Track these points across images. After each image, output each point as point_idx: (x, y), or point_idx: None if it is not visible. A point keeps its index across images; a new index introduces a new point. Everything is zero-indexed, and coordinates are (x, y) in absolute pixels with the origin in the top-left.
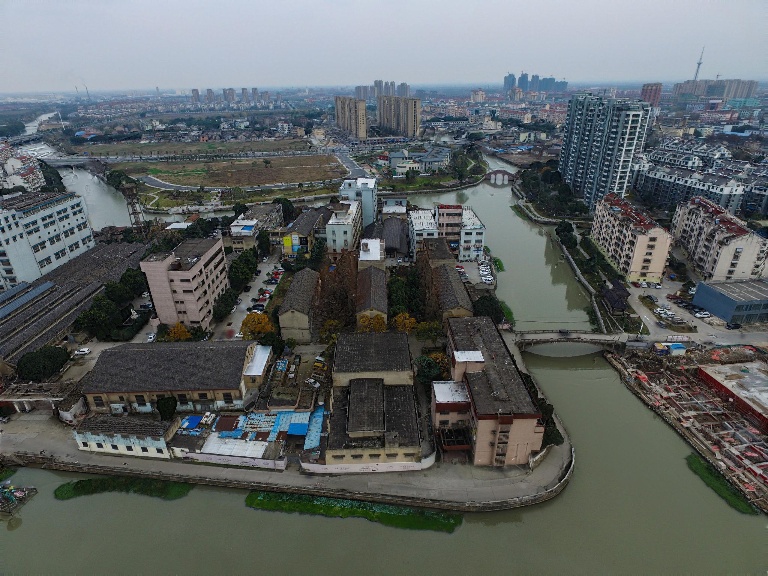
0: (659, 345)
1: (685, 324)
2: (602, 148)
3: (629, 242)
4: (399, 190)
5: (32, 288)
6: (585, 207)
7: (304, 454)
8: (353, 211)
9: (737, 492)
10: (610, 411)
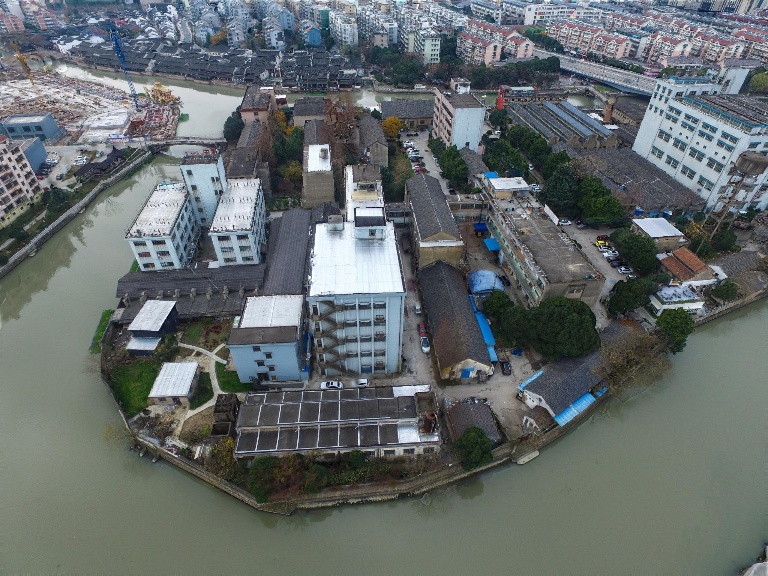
0: None
1: None
2: None
3: None
4: None
5: (607, 140)
6: None
7: None
8: (351, 198)
9: (180, 116)
10: (198, 131)
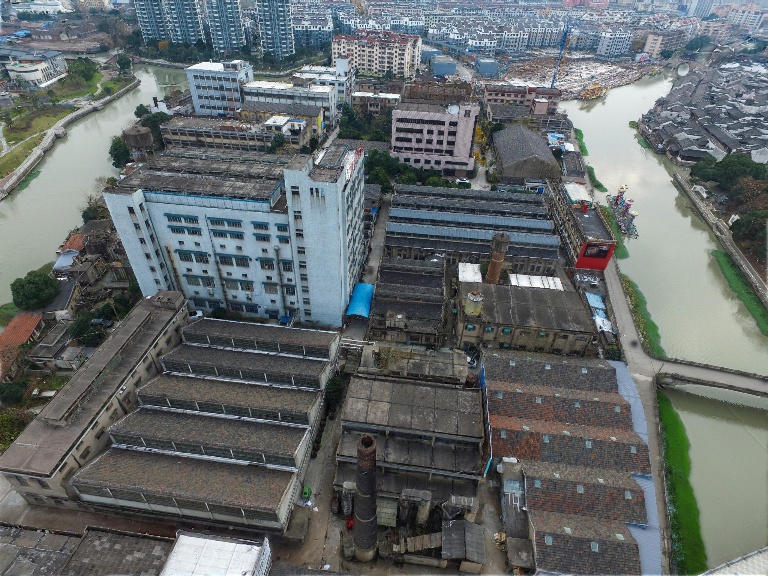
0: (477, 84)
1: (454, 80)
2: (275, 6)
3: (399, 55)
4: (111, 93)
5: None
6: (295, 56)
7: (568, 136)
8: None
9: None
10: None
